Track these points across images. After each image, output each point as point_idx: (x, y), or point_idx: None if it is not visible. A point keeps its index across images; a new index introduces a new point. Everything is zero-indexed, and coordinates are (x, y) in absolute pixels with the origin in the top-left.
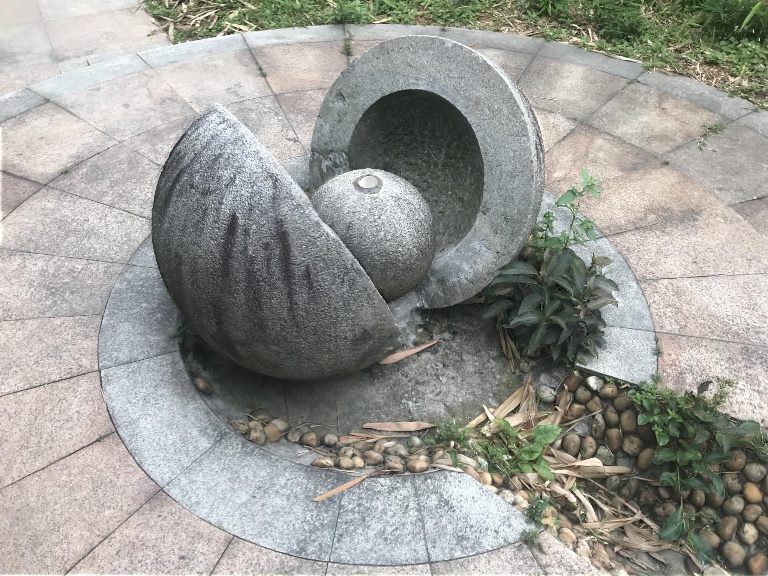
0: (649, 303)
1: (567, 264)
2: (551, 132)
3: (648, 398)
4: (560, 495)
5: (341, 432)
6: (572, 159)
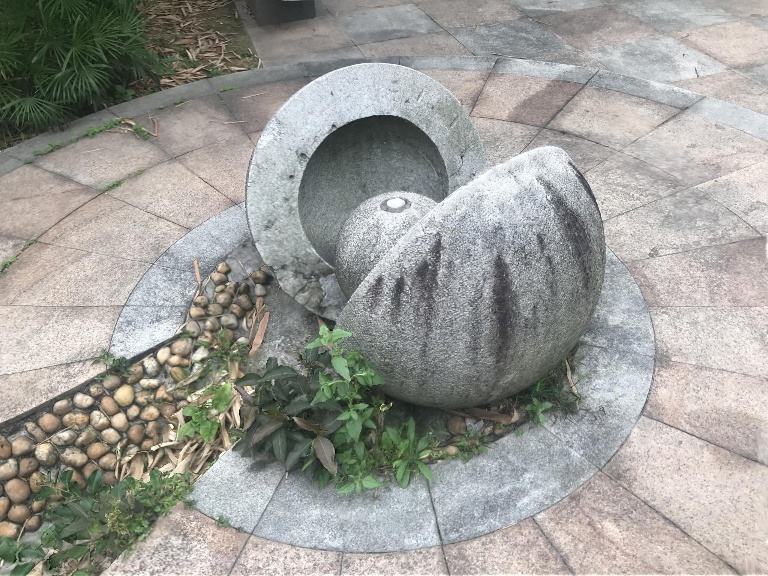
0: (298, 548)
1: (324, 406)
2: (765, 562)
3: (168, 479)
4: (164, 441)
5: (269, 300)
6: (667, 569)
